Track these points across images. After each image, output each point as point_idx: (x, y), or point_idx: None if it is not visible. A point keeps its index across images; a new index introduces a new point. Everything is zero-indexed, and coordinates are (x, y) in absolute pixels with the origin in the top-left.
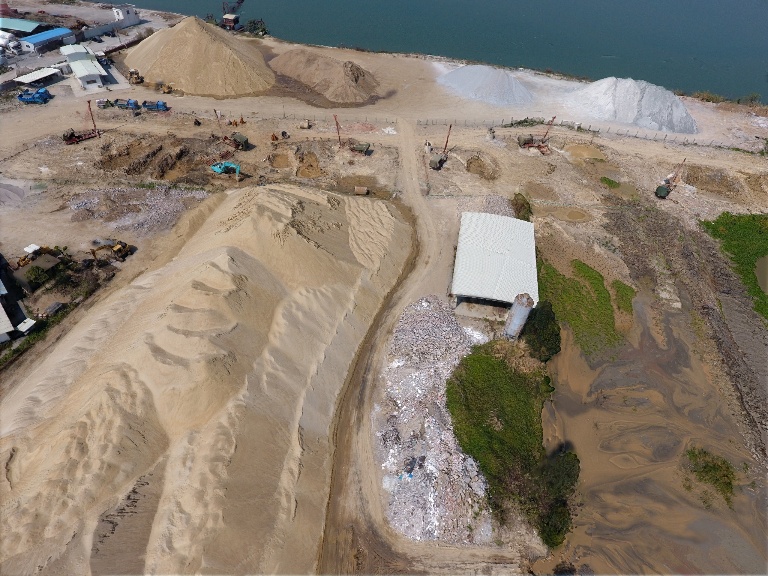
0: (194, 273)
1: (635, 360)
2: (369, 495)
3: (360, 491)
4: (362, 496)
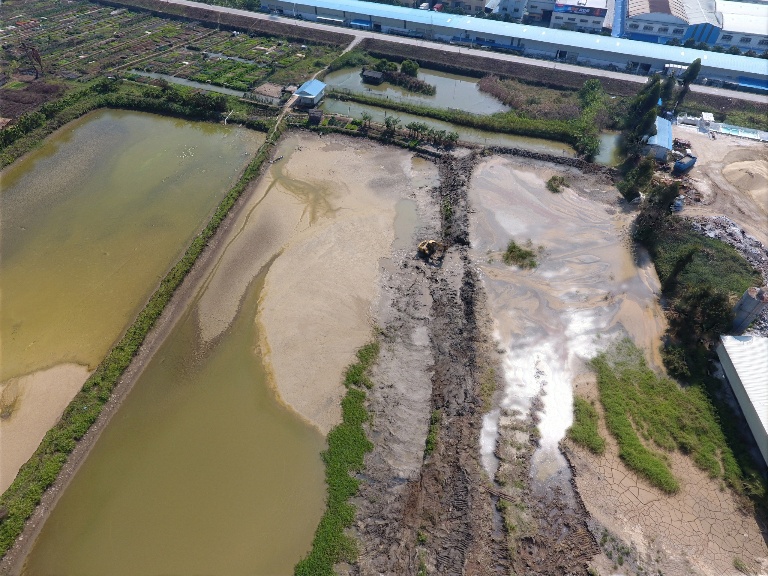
0: None
1: (574, 337)
2: (759, 233)
3: (766, 234)
4: (763, 232)
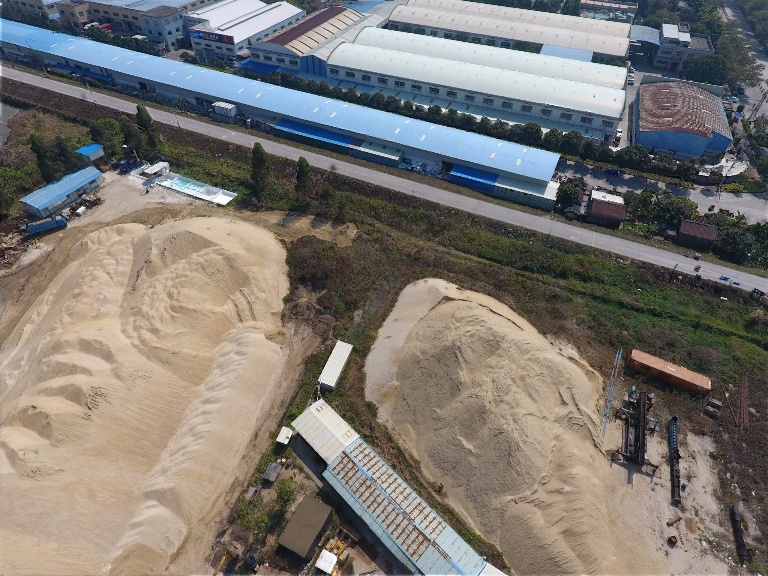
0: (51, 461)
1: None
2: None
3: None
4: None
